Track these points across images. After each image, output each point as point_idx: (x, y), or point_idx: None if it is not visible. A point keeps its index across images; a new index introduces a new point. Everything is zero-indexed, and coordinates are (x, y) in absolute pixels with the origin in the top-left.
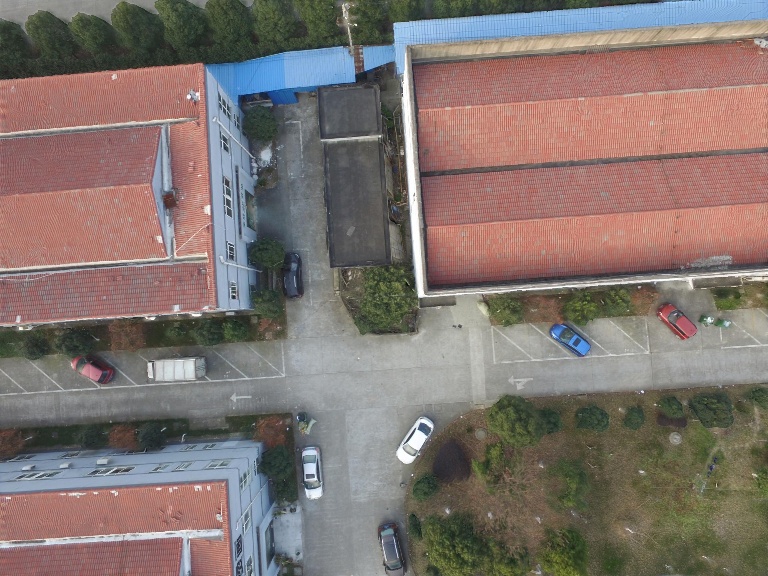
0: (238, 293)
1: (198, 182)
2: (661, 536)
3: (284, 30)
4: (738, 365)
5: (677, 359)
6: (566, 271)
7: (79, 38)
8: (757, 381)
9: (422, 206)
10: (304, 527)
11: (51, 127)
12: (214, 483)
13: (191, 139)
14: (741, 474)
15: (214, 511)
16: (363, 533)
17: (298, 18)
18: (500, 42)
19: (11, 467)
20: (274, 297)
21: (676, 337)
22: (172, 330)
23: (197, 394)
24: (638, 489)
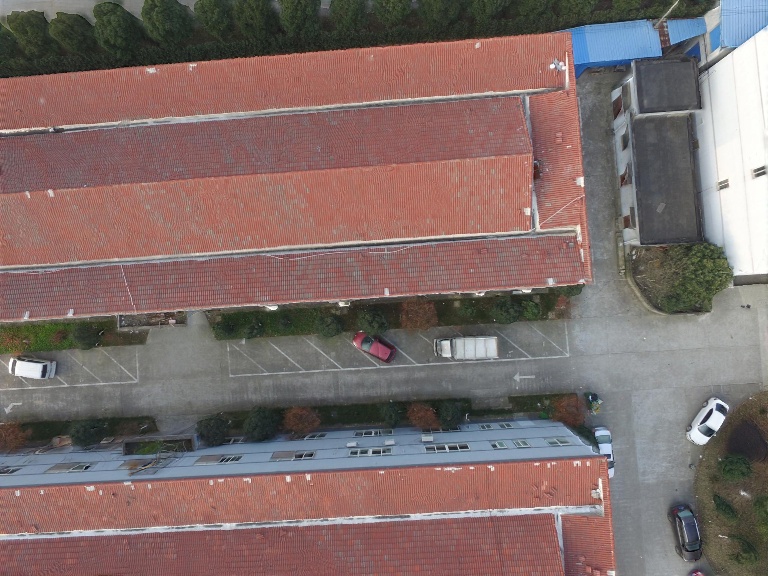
0: None
1: (568, 153)
2: None
3: (594, 2)
4: None
5: None
6: None
7: (382, 10)
8: None
9: None
10: None
11: (405, 97)
12: (595, 458)
13: (558, 109)
14: None
15: (589, 487)
16: (652, 514)
17: None
18: None
19: (324, 444)
20: None
21: None
22: (468, 308)
23: (479, 374)
24: None
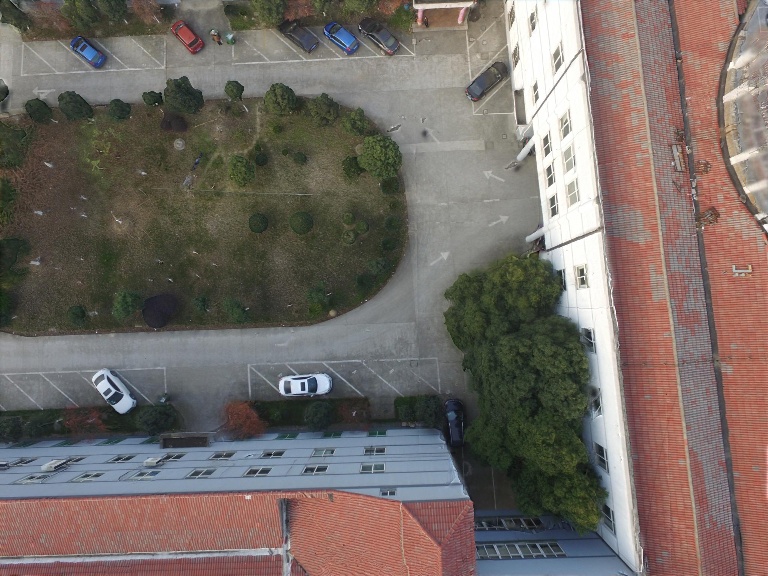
0: None
1: None
2: (156, 233)
3: None
4: (246, 80)
5: (190, 74)
6: None
7: None
8: (263, 95)
9: None
10: None
11: None
12: None
13: None
14: None
15: None
16: None
17: None
18: None
19: None
20: None
21: (190, 54)
22: None
23: None
24: None
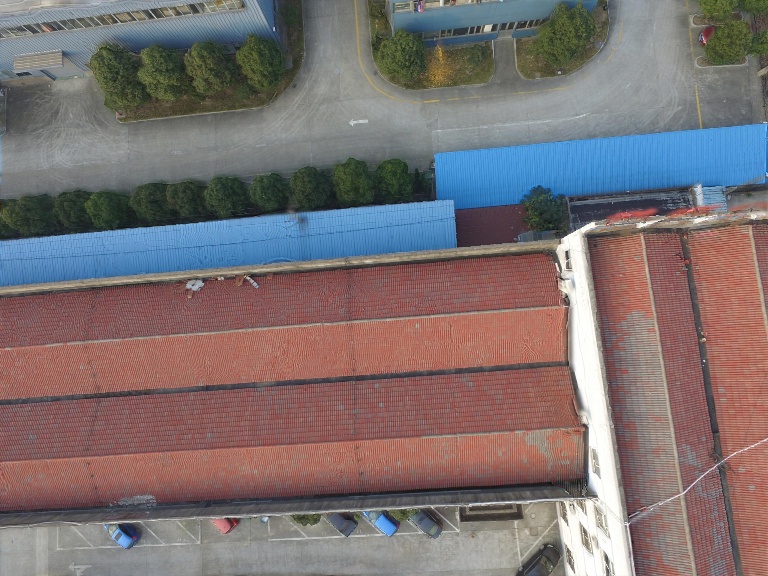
0: None
1: None
2: None
3: None
4: (284, 558)
5: (226, 550)
6: (5, 507)
7: None
8: (302, 574)
9: None
10: None
11: None
12: None
13: None
14: None
15: None
16: None
17: None
18: None
19: None
20: None
21: None
22: None
23: None
24: None
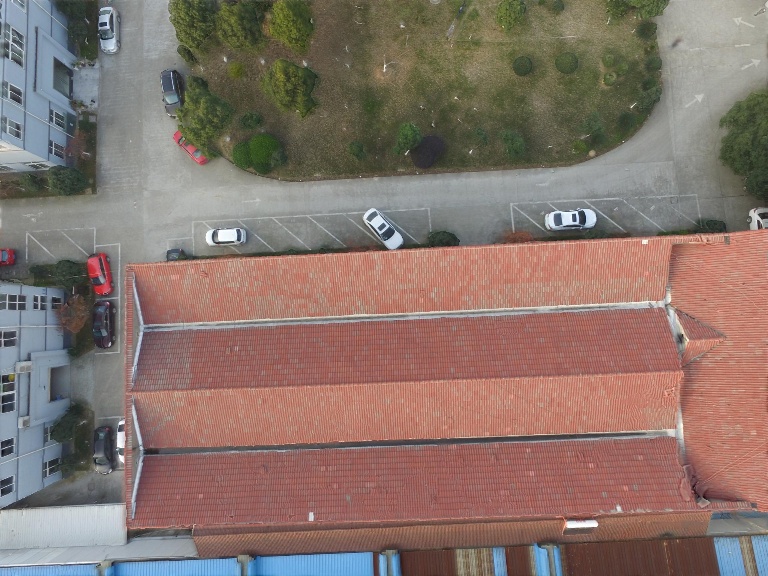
0: None
1: None
2: (417, 81)
3: None
4: None
5: None
6: None
7: None
8: None
9: None
10: (101, 81)
11: None
12: None
13: None
14: (493, 28)
15: None
16: (152, 85)
17: None
18: None
19: None
20: None
21: None
22: None
23: None
24: (399, 42)
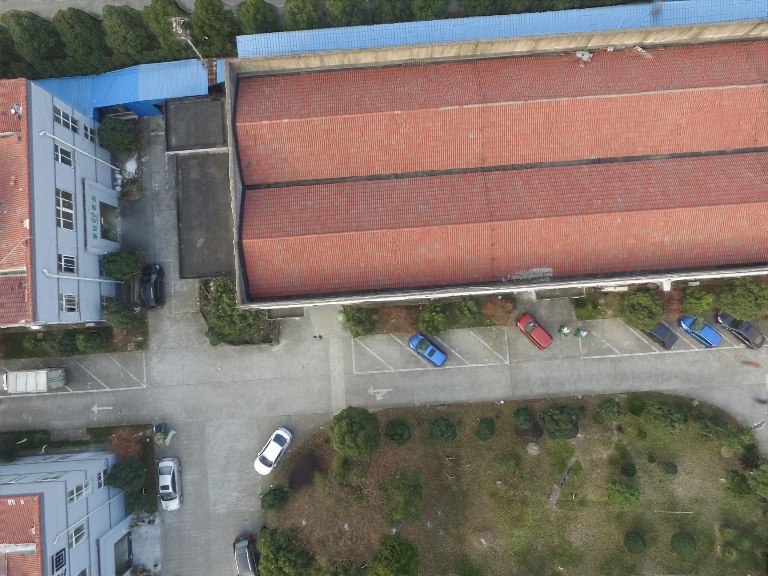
0: (79, 305)
1: (18, 196)
2: (518, 547)
3: (135, 43)
4: (597, 375)
5: (536, 369)
6: (387, 283)
7: None
8: (616, 391)
9: (241, 219)
10: (163, 538)
11: None
12: (27, 497)
13: (13, 153)
14: (599, 485)
15: (29, 525)
16: (221, 544)
17: (149, 31)
18: (318, 56)
19: None
20: (124, 309)
21: (535, 347)
22: (27, 342)
23: (59, 405)
24: (495, 500)
